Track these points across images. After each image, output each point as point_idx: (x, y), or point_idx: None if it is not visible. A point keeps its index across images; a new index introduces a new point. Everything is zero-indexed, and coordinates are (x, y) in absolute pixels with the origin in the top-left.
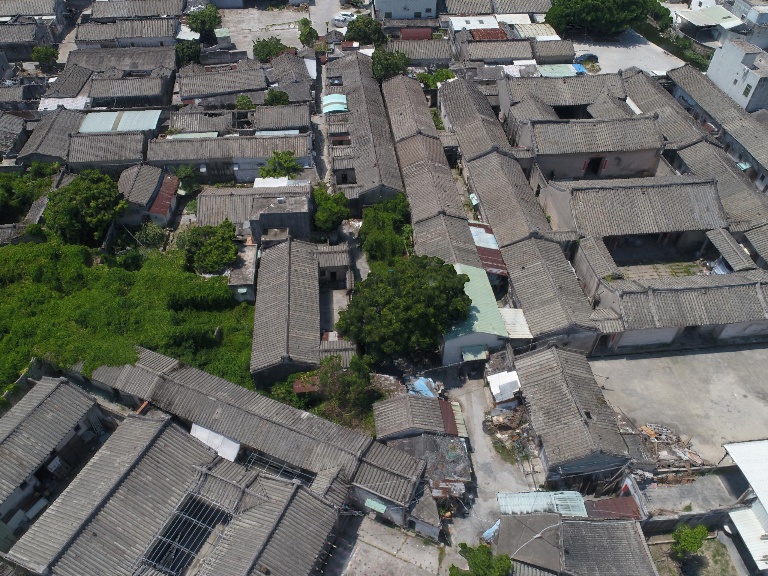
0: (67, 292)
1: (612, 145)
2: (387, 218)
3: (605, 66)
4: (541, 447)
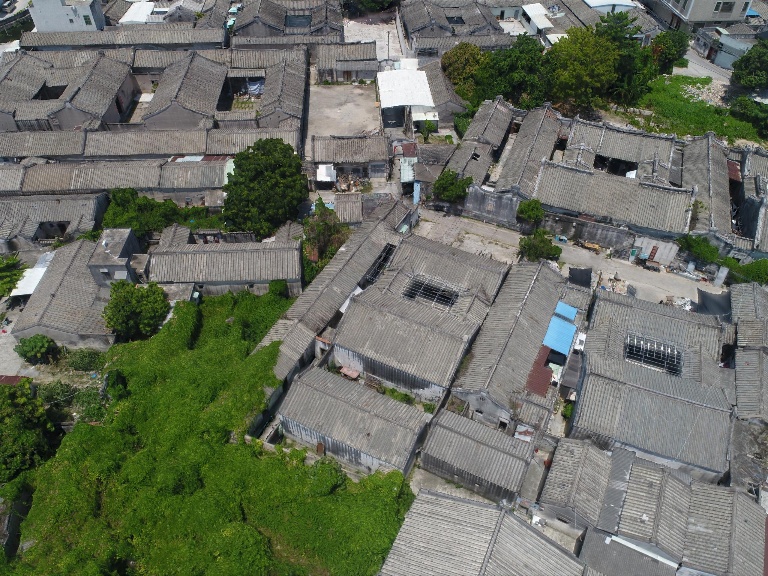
0: (134, 451)
1: (115, 83)
2: (145, 200)
3: None
4: (367, 172)
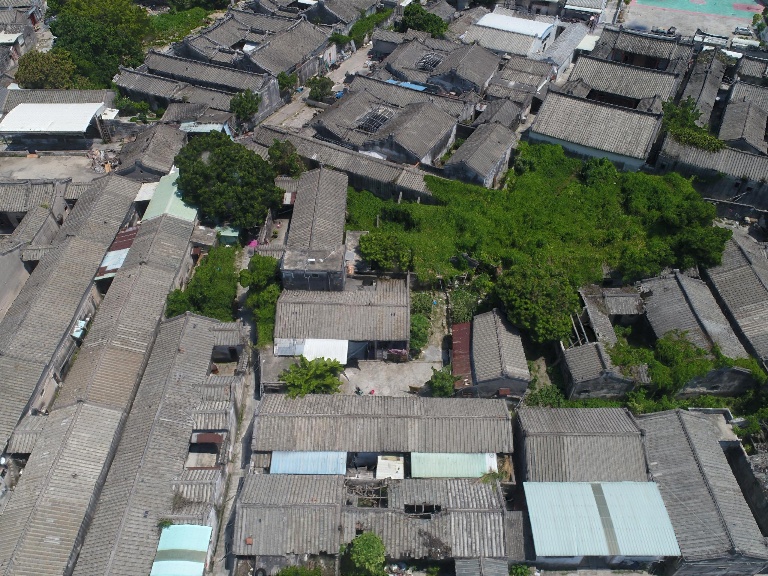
0: None
1: None
2: (202, 276)
3: None
4: None
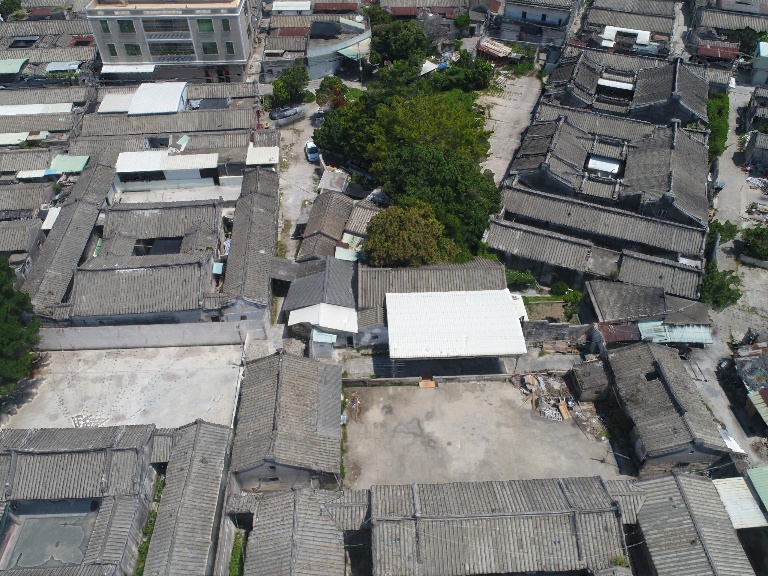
0: None
1: None
2: None
3: None
4: None
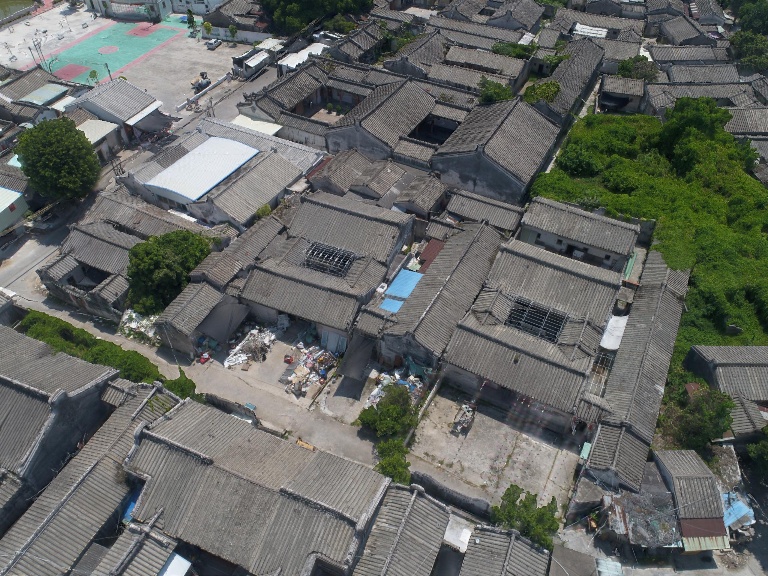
0: (731, 227)
1: None
2: None
3: None
4: None
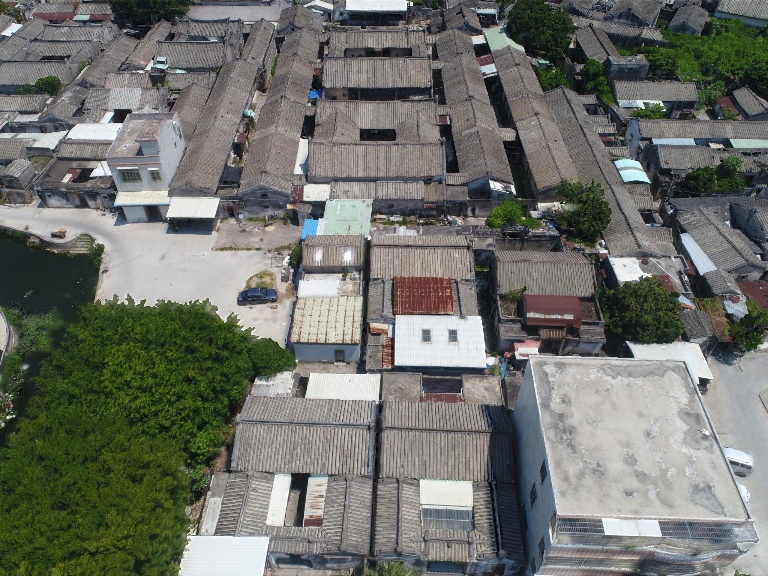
0: None
1: None
2: None
3: (236, 286)
4: None
